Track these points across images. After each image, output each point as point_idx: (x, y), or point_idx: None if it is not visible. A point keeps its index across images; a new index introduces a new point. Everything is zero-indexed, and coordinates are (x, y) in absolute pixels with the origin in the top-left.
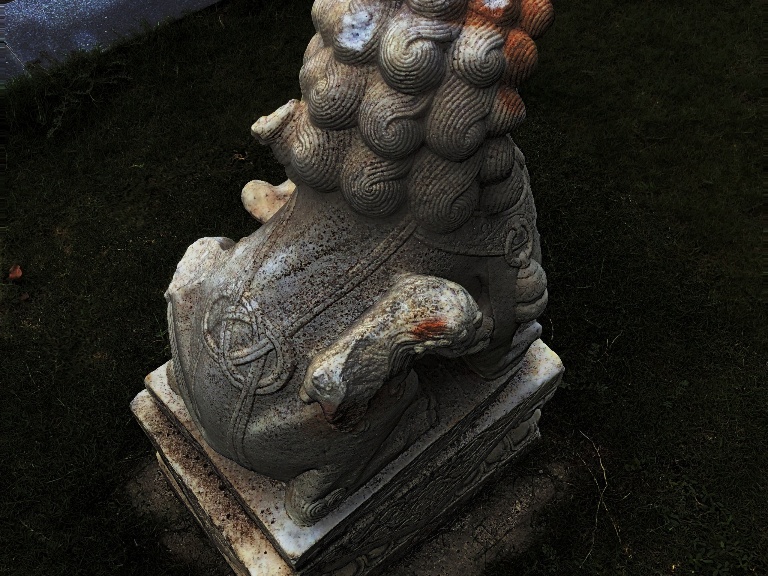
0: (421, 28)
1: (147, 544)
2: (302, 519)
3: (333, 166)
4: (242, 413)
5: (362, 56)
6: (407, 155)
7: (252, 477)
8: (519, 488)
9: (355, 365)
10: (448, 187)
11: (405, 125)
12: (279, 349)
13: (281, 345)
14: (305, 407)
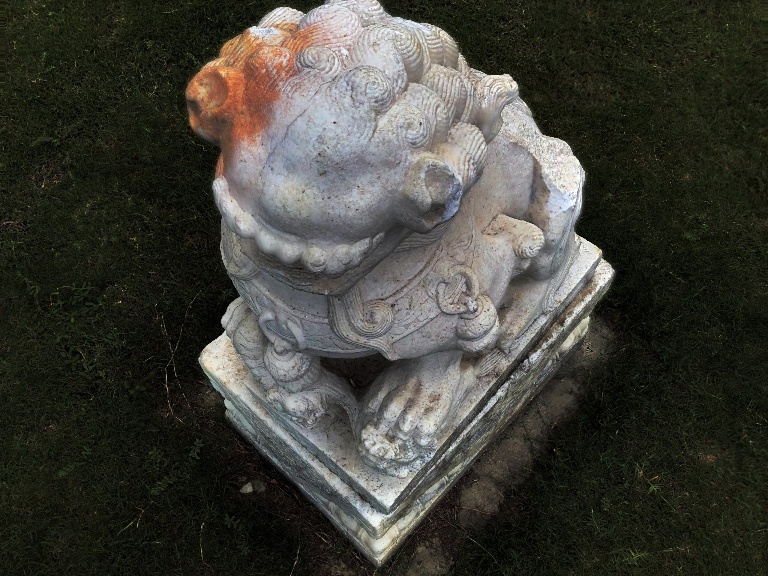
0: (343, 5)
1: None
2: None
3: None
4: None
5: None
6: None
7: None
8: None
9: None
10: None
11: None
12: None
13: None
14: None
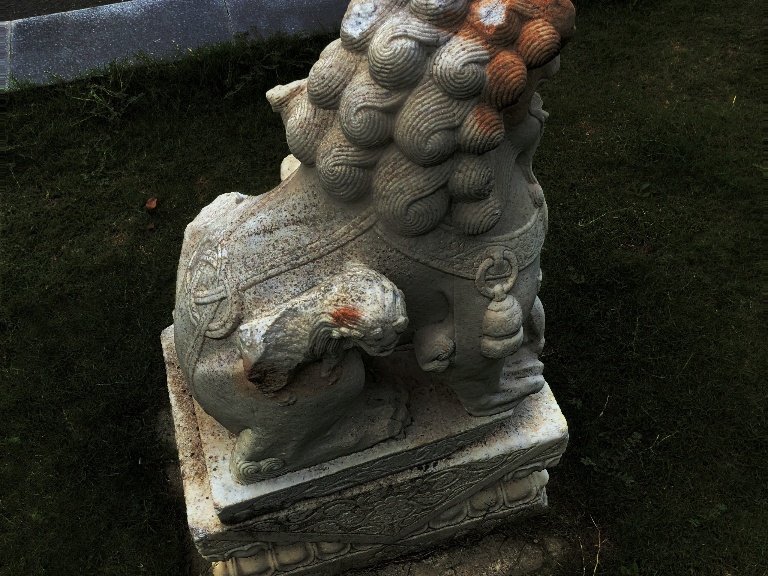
0: (410, 27)
1: (150, 466)
2: (237, 475)
3: (312, 141)
4: (194, 350)
5: (358, 44)
6: (374, 146)
7: (216, 424)
8: (507, 548)
9: (280, 331)
10: (407, 188)
11: (372, 115)
12: (230, 298)
13: (232, 295)
14: (239, 360)
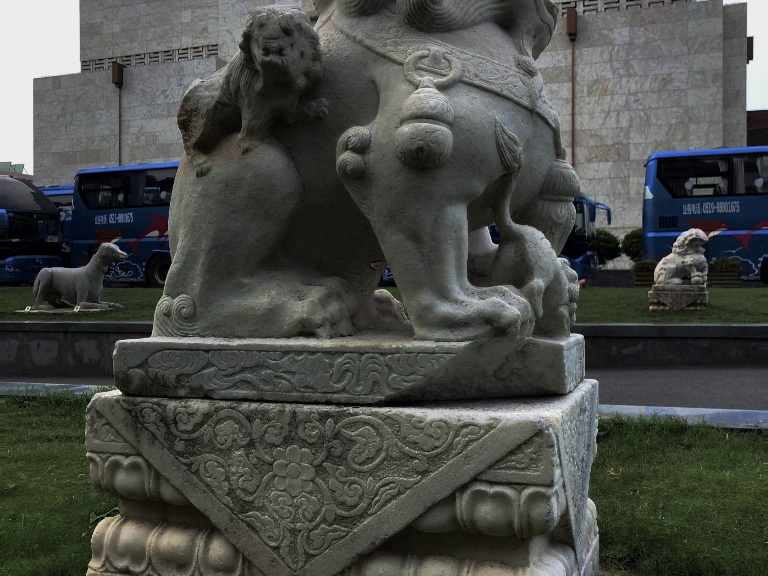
0: None
1: None
2: None
3: None
4: None
5: None
6: None
7: None
8: None
9: None
10: None
11: None
12: None
13: None
14: None
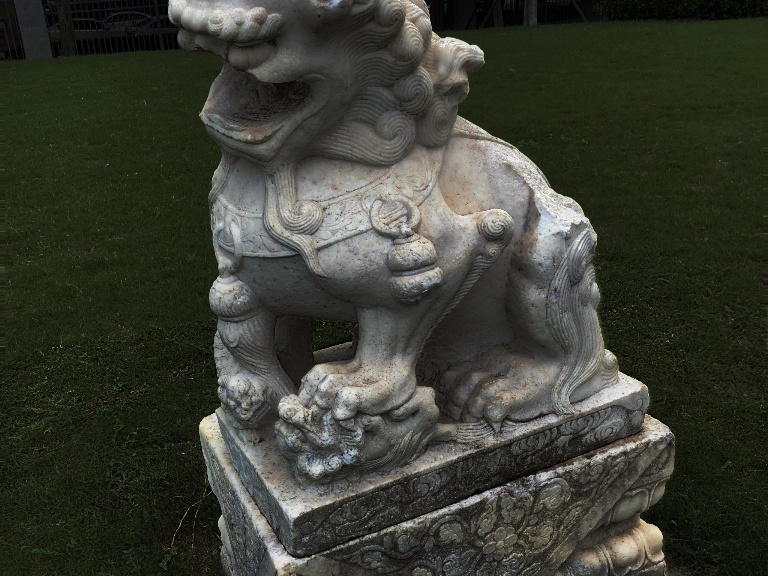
0: None
1: None
2: None
3: None
4: None
5: None
6: None
7: None
8: None
9: None
10: None
11: None
12: None
13: None
14: None
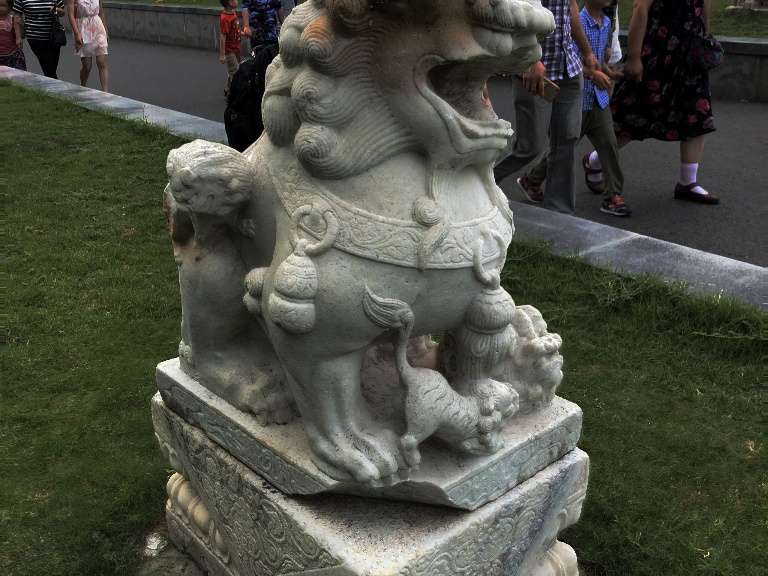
0: None
1: None
2: None
3: None
4: None
5: None
6: None
7: None
8: None
9: None
10: None
11: None
12: None
13: None
14: None
